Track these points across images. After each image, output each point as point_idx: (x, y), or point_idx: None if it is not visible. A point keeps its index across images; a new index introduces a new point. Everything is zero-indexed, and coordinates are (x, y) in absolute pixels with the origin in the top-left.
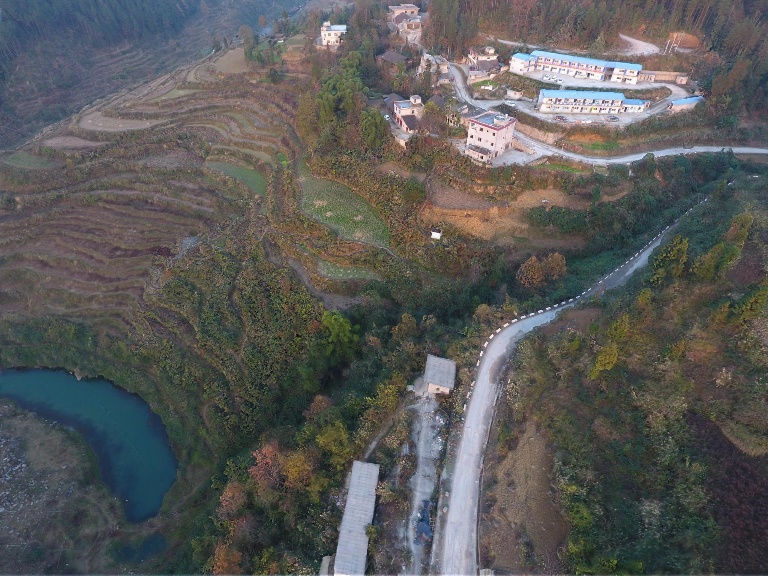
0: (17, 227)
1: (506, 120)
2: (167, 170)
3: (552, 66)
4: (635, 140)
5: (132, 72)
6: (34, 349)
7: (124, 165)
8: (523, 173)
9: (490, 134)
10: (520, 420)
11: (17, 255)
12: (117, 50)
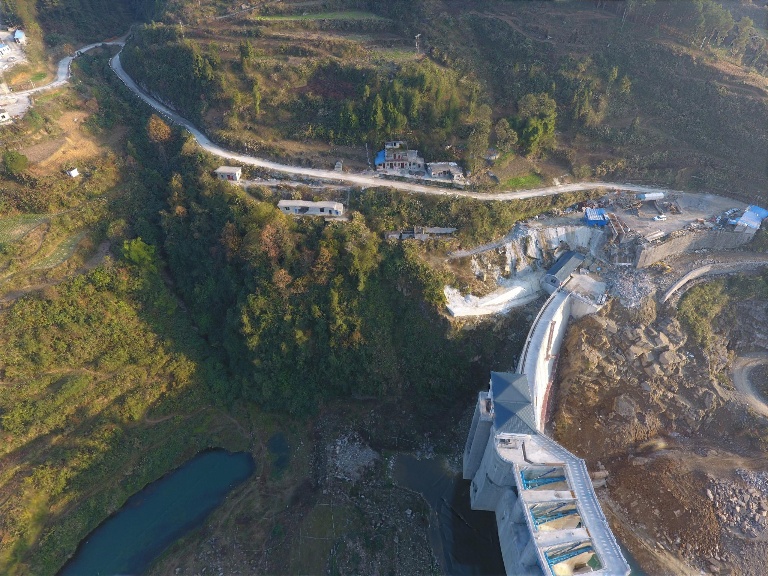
0: None
1: None
2: None
3: None
4: (41, 67)
5: None
6: None
7: None
8: (42, 110)
9: None
10: None
11: None
12: None
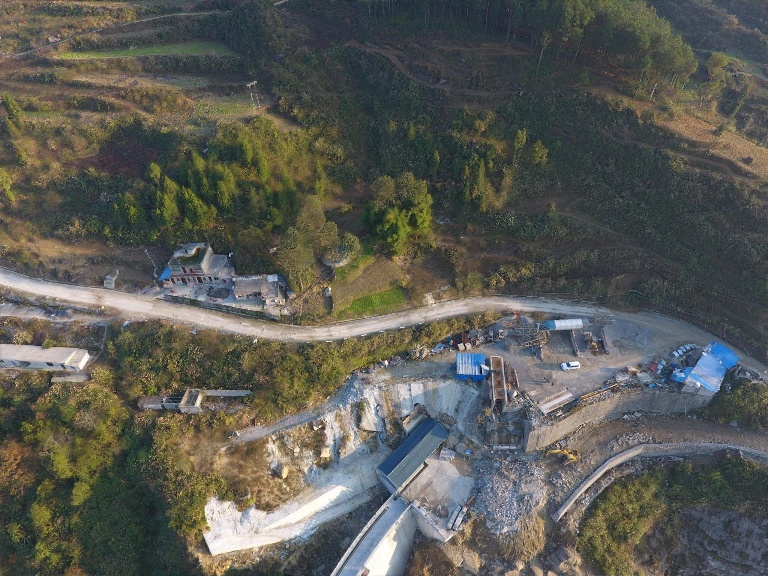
0: None
1: None
2: None
3: None
4: None
5: None
6: None
7: None
8: None
9: None
10: (19, 249)
11: None
12: None
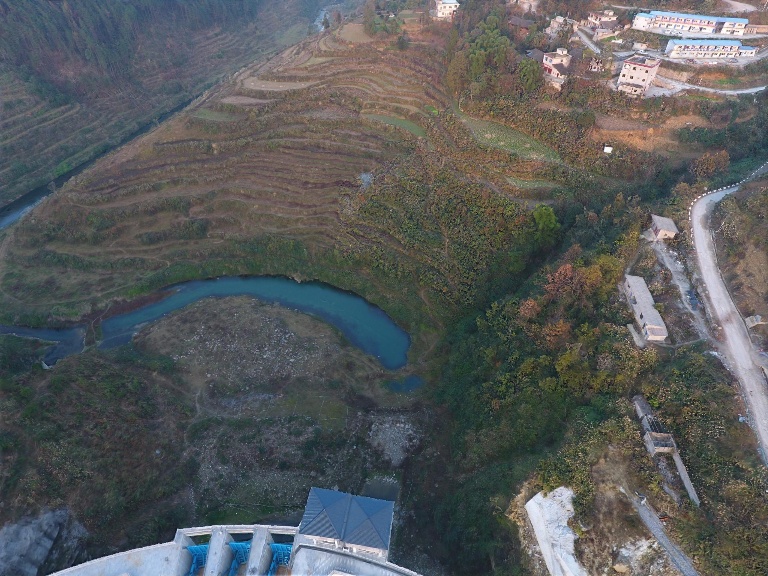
0: (218, 168)
1: (657, 60)
2: (332, 121)
3: (668, 23)
4: (752, 77)
5: (226, 52)
6: (258, 260)
7: (292, 118)
8: (671, 102)
9: (643, 72)
10: (741, 243)
11: (224, 190)
12: (210, 32)
